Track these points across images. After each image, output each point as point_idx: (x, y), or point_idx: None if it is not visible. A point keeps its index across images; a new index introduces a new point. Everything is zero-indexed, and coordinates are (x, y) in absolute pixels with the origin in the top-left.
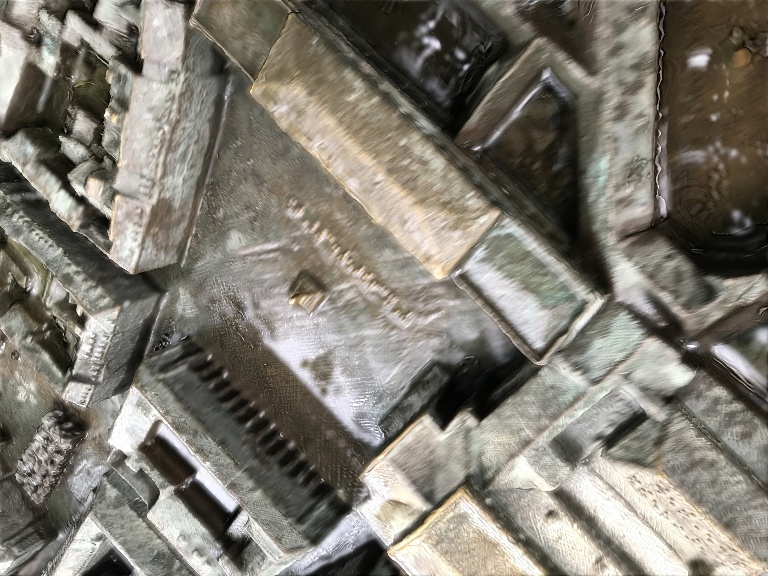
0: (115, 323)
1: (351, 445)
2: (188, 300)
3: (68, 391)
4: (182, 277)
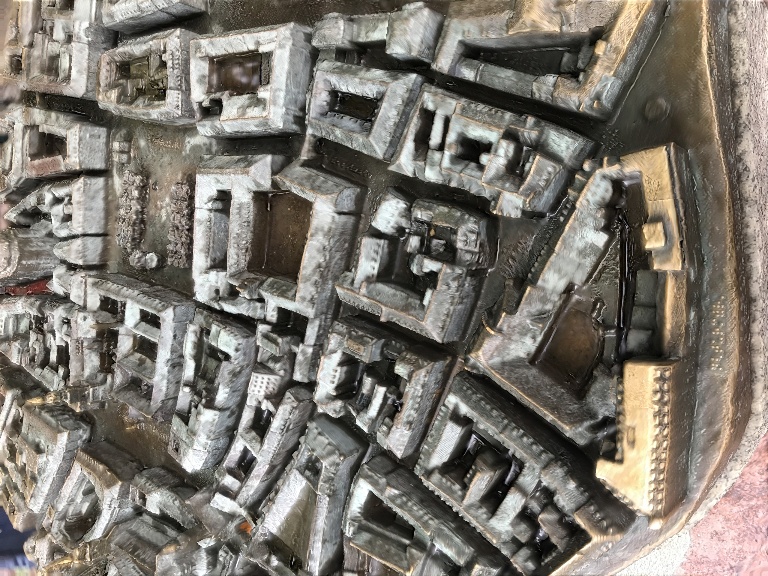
0: (179, 39)
1: (308, 2)
2: (217, 29)
3: (167, 97)
4: (211, 21)
